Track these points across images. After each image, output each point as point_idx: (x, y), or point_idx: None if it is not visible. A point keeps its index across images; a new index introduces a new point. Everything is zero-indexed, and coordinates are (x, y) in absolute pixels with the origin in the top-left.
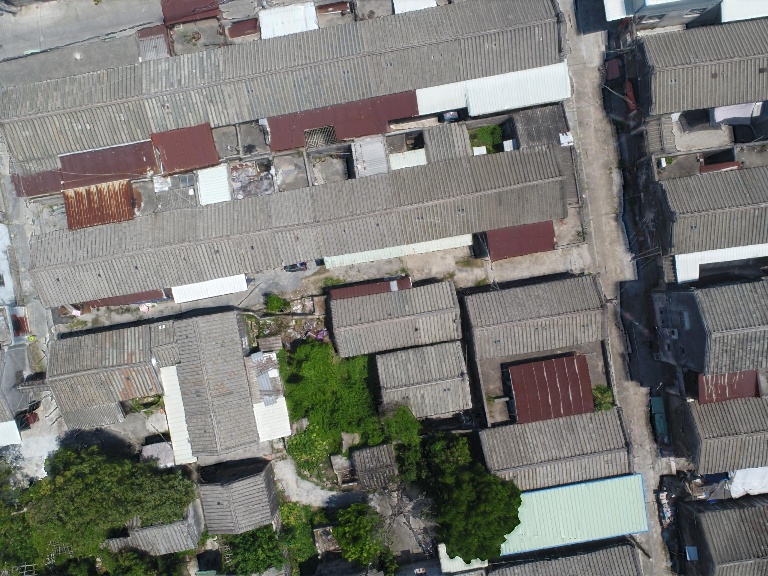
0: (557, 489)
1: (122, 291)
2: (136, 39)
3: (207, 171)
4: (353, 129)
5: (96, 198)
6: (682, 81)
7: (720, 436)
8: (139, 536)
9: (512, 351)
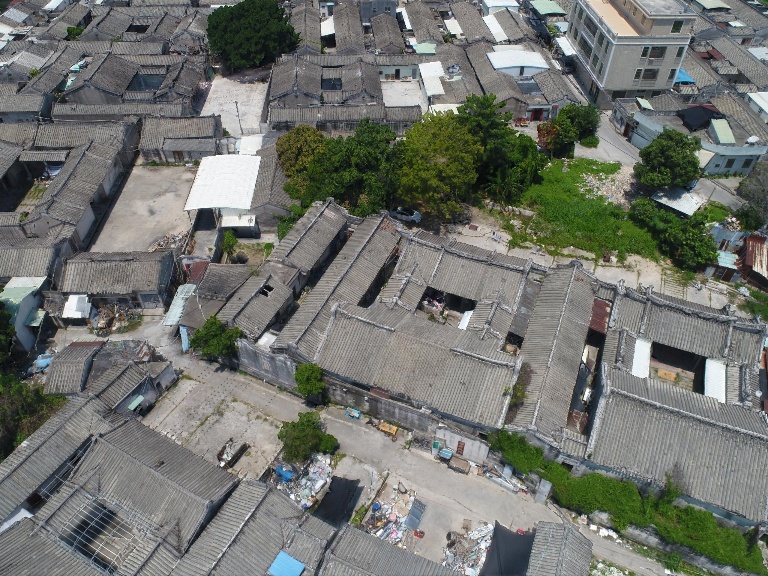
0: None
1: None
2: None
3: None
4: None
5: None
6: (460, 5)
7: (346, 5)
8: None
9: None
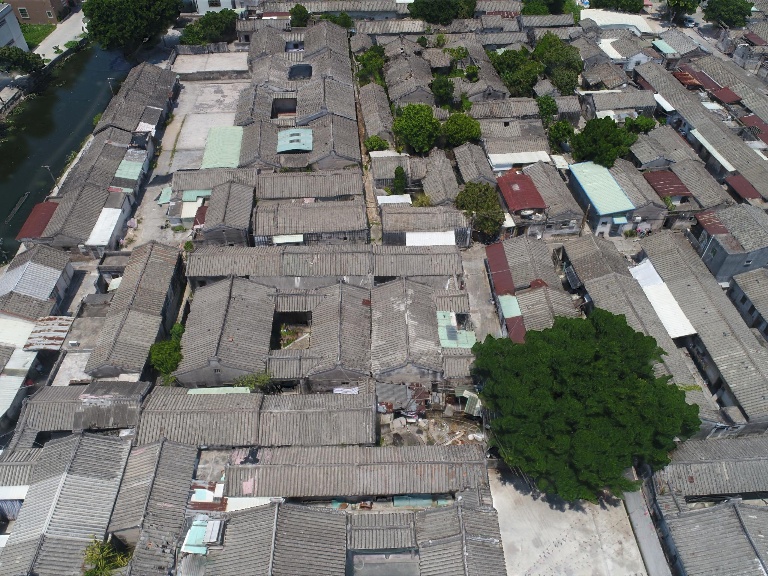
0: (614, 180)
1: (651, 82)
2: (766, 88)
3: (717, 105)
4: (766, 139)
5: (689, 78)
6: None
7: None
8: (544, 81)
9: (681, 176)
